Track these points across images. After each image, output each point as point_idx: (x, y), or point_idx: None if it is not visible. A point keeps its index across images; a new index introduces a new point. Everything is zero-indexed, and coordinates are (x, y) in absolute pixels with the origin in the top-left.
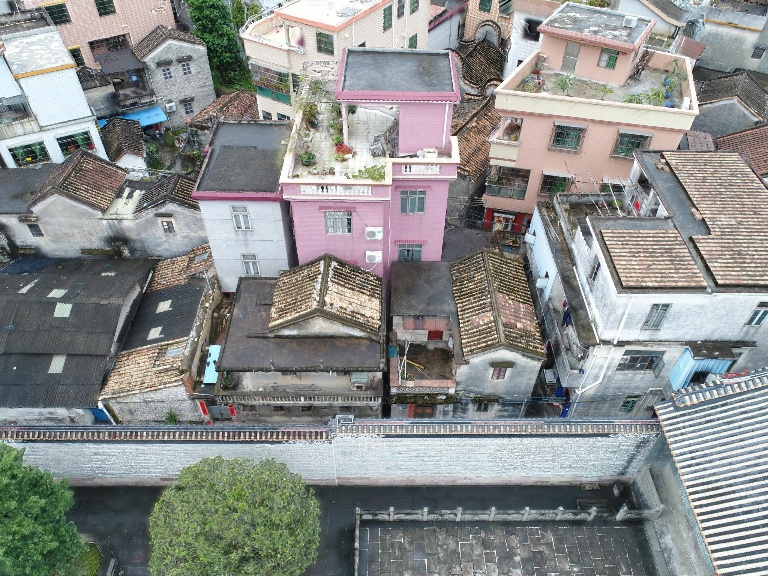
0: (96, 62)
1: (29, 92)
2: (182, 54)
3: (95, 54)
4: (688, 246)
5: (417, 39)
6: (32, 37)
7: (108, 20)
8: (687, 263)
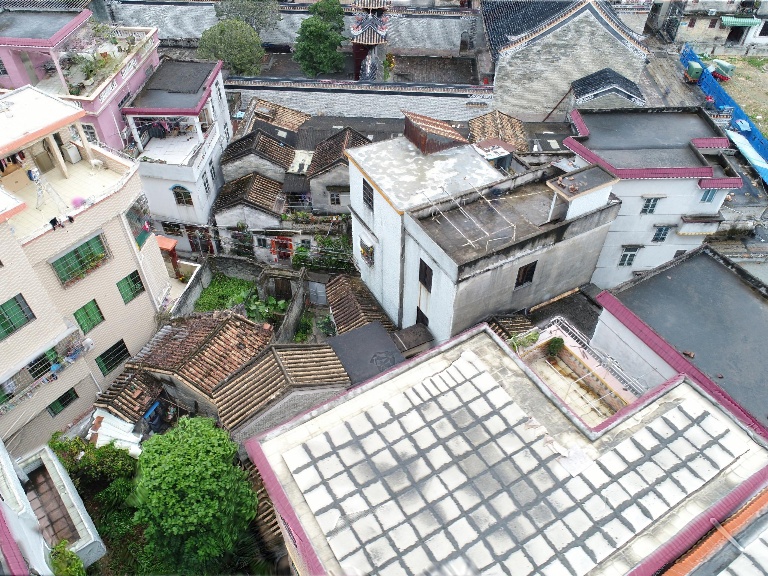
0: None
1: None
2: None
3: None
4: None
5: None
6: None
7: None
8: None
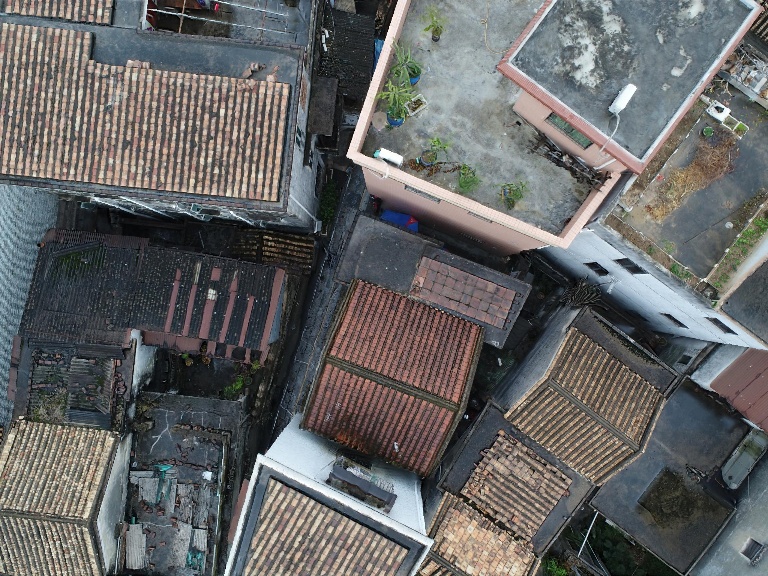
0: None
1: None
2: None
3: None
4: (78, 24)
5: None
6: None
7: None
8: (46, 6)
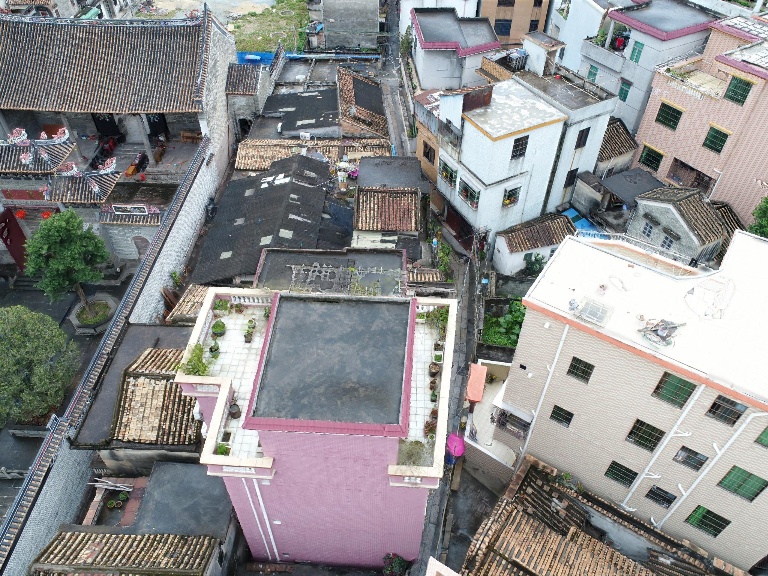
0: (667, 178)
1: (466, 133)
2: (673, 228)
3: (681, 173)
4: None
5: (767, 489)
6: (547, 106)
7: (707, 154)
8: None
